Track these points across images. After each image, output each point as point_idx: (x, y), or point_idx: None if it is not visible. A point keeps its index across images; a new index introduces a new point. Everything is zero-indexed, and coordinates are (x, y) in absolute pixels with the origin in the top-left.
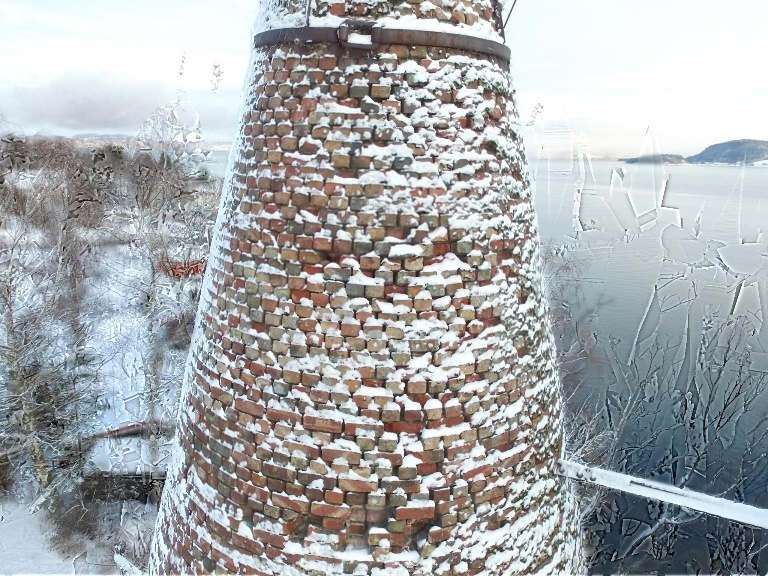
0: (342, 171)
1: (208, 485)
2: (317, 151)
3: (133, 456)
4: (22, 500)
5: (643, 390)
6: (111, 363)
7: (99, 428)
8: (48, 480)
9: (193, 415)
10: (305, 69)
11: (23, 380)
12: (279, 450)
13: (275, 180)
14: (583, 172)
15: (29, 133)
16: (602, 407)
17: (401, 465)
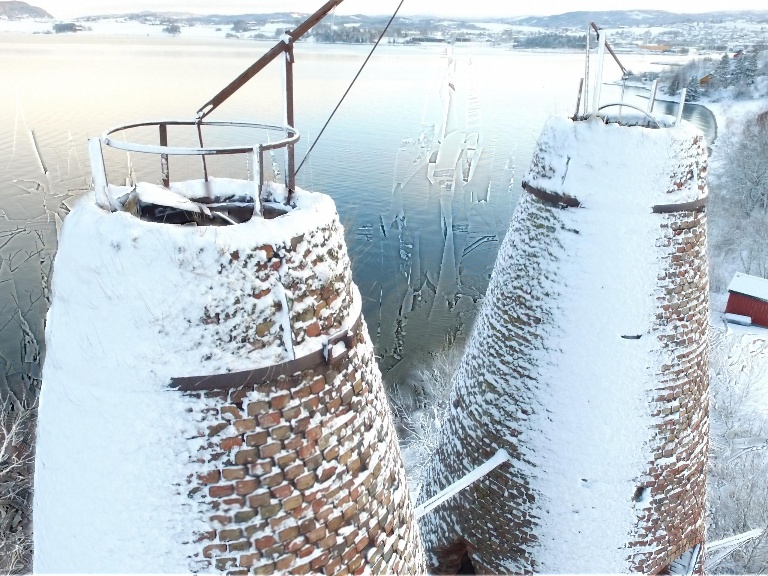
0: None
1: None
2: (336, 471)
3: None
4: None
5: None
6: None
7: None
8: None
9: None
10: (299, 402)
11: None
12: None
13: (304, 524)
14: None
15: None
16: (7, 395)
17: None
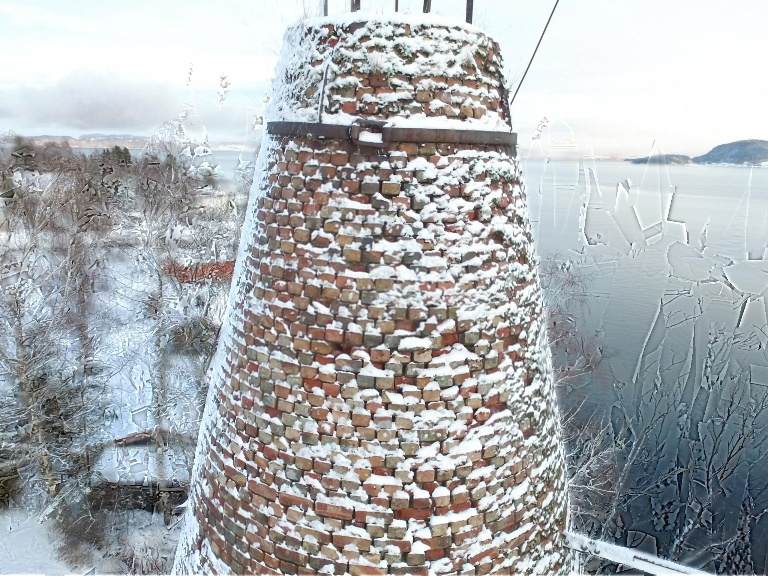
0: (353, 264)
1: (222, 561)
2: (329, 245)
3: (140, 467)
4: (31, 512)
5: (647, 436)
6: (119, 375)
7: (107, 441)
8: (56, 490)
9: (207, 489)
10: (317, 164)
11: (32, 393)
12: (291, 534)
13: (288, 270)
14: (589, 185)
15: (39, 148)
16: (607, 424)
17: (410, 551)
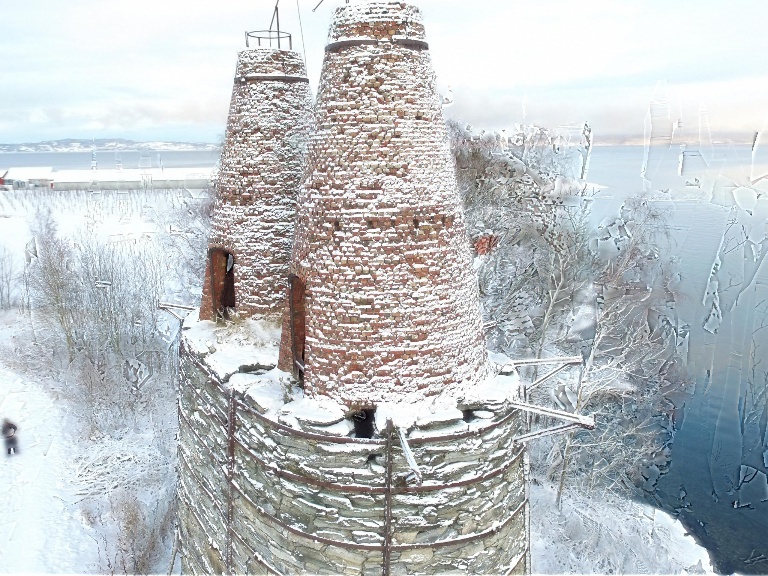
0: None
1: None
2: None
3: None
4: None
5: None
6: None
7: None
8: None
9: None
10: None
11: None
12: None
13: None
14: (702, 137)
15: None
16: (645, 322)
17: None
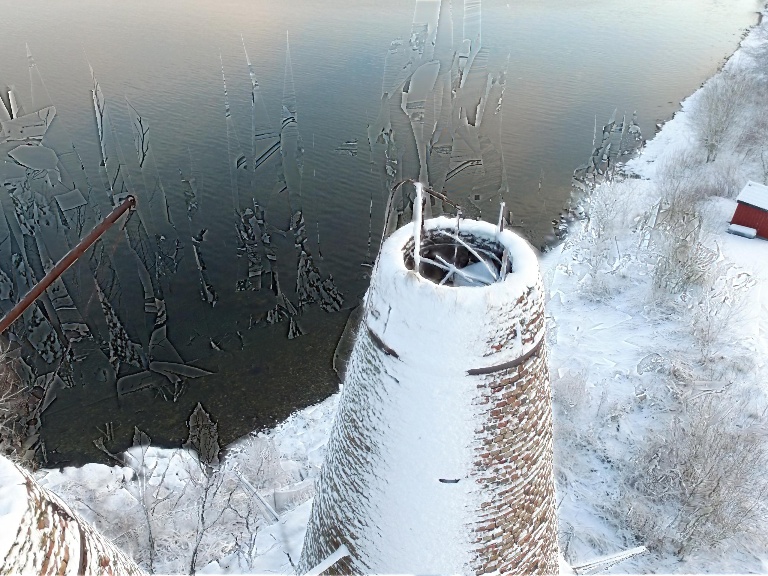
0: None
1: None
2: None
3: None
4: None
5: None
6: None
7: None
8: None
9: None
10: None
11: None
12: None
13: None
14: None
15: None
16: None
17: None
